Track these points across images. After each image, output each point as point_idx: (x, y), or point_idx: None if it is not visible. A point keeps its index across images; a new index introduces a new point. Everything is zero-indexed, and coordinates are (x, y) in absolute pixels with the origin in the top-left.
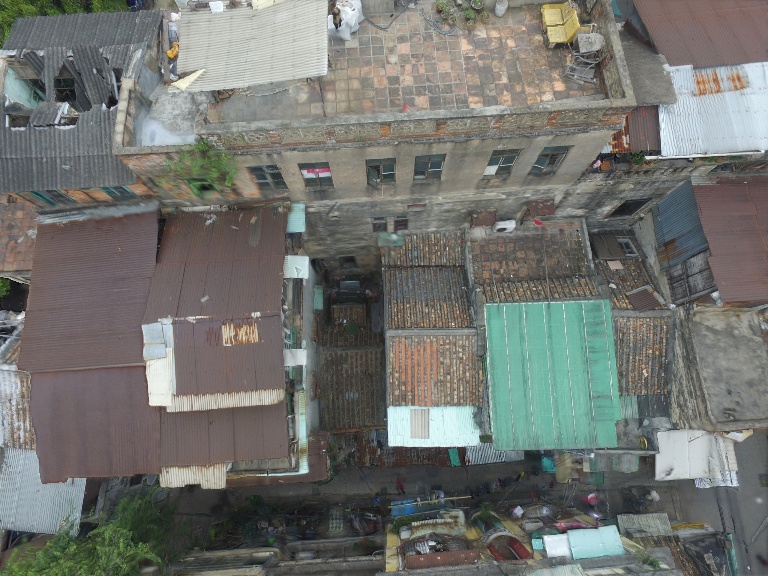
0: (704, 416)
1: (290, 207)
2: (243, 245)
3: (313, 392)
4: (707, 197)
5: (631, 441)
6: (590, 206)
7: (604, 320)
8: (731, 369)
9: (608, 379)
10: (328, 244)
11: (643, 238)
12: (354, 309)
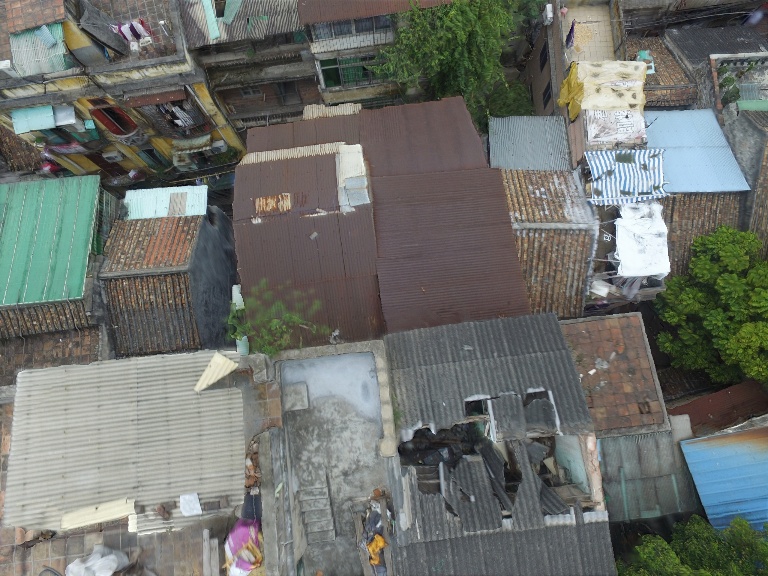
0: None
1: None
2: (289, 303)
3: None
4: None
5: None
6: None
7: None
8: None
9: None
10: None
11: None
12: None
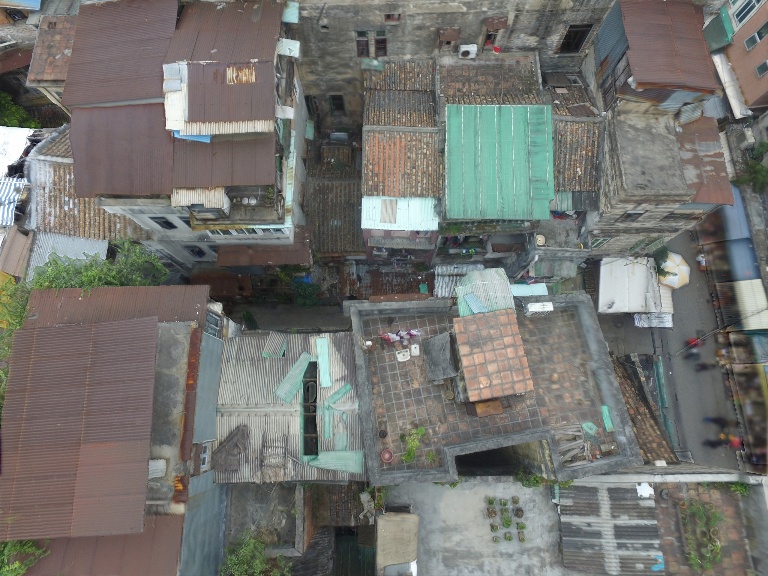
0: (620, 188)
1: (286, 2)
2: (246, 21)
3: (301, 198)
4: (631, 8)
5: None
6: (540, 32)
7: (545, 121)
8: (647, 157)
9: (545, 167)
10: (319, 72)
11: (587, 71)
12: (341, 150)
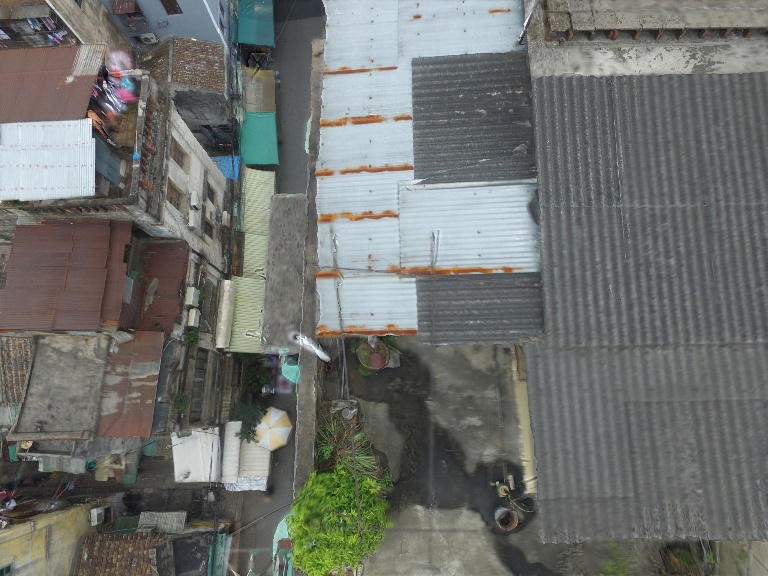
0: None
1: None
2: None
3: None
4: (26, 235)
5: (72, 446)
6: None
7: None
8: (60, 387)
9: None
10: None
11: None
12: None
